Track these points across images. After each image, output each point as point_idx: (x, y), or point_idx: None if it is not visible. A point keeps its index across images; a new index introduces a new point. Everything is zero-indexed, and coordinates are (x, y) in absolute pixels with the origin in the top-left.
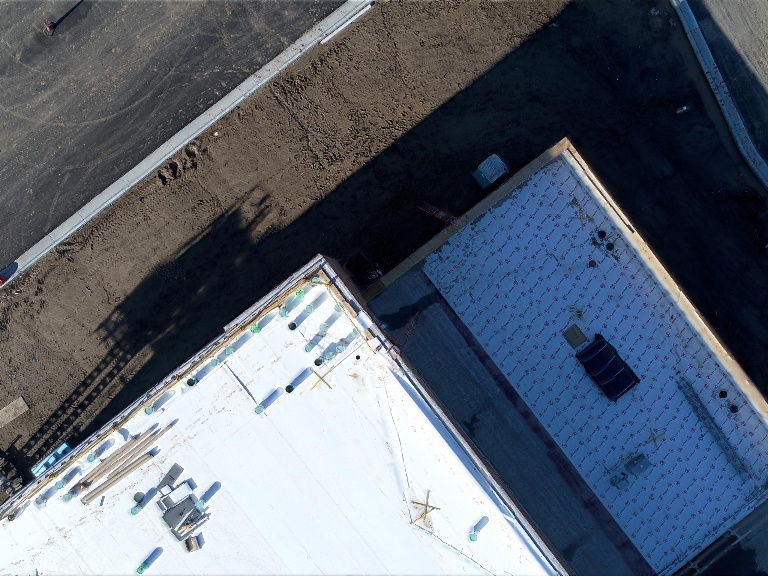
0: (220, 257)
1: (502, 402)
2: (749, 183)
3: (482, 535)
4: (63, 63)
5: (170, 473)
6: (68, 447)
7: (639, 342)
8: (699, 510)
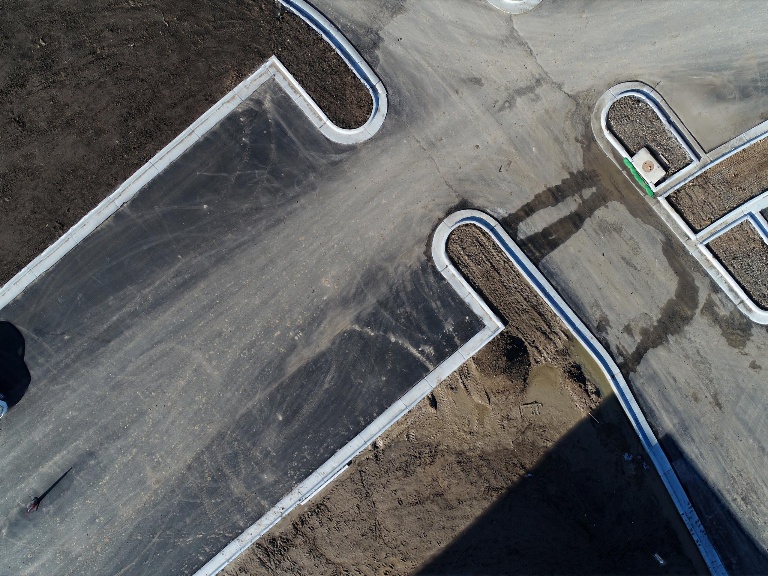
0: None
1: None
2: None
3: None
4: (48, 535)
5: None
6: None
7: None
8: None
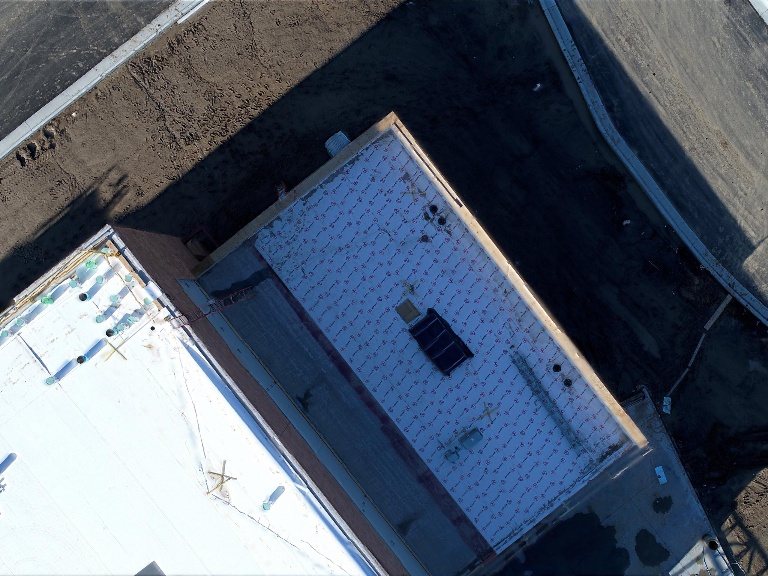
0: (79, 238)
1: (335, 377)
2: (608, 160)
3: (278, 504)
4: None
5: None
6: None
7: (472, 316)
8: (534, 483)
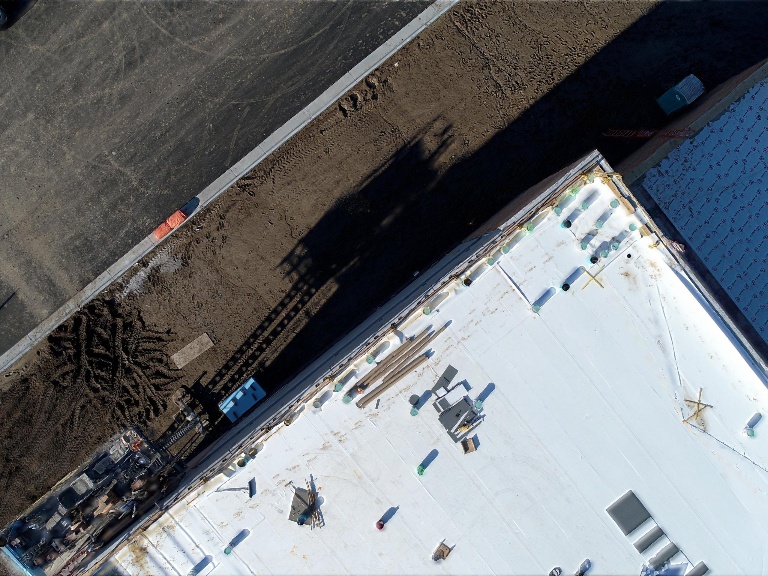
0: (403, 188)
1: None
2: None
3: (755, 432)
4: None
5: (444, 375)
6: (255, 382)
7: None
8: None
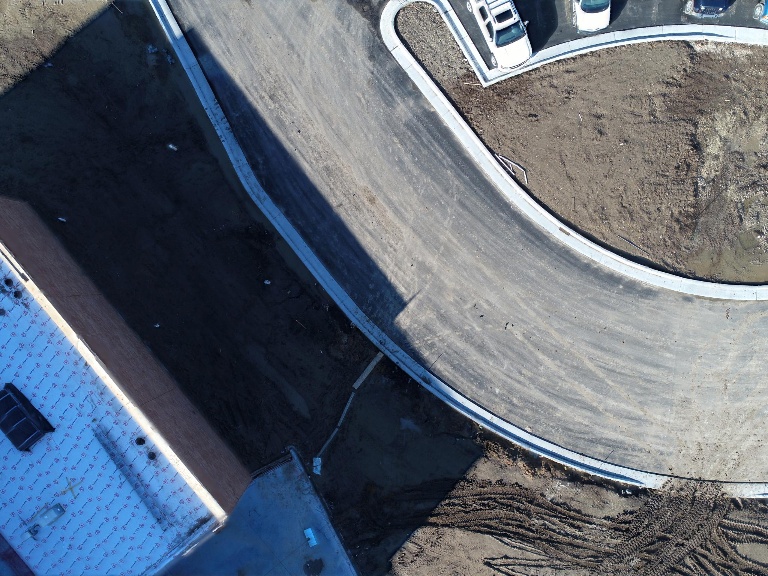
0: None
1: None
2: (256, 219)
3: None
4: None
5: None
6: None
7: (53, 390)
8: (120, 559)
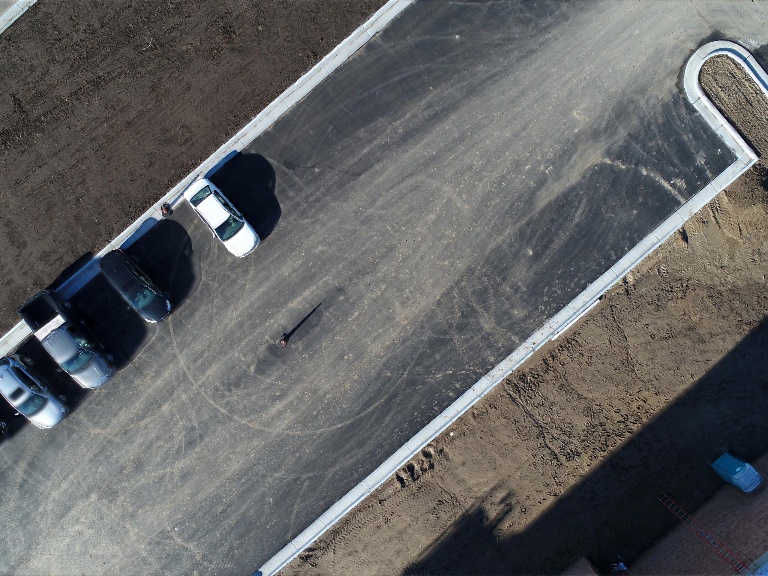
0: (462, 556)
1: None
2: None
3: None
4: (297, 372)
5: None
6: None
7: None
8: None
